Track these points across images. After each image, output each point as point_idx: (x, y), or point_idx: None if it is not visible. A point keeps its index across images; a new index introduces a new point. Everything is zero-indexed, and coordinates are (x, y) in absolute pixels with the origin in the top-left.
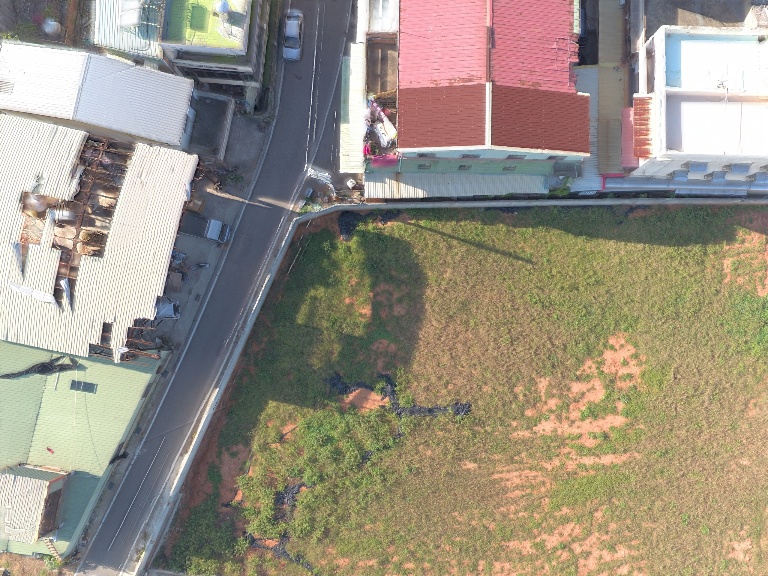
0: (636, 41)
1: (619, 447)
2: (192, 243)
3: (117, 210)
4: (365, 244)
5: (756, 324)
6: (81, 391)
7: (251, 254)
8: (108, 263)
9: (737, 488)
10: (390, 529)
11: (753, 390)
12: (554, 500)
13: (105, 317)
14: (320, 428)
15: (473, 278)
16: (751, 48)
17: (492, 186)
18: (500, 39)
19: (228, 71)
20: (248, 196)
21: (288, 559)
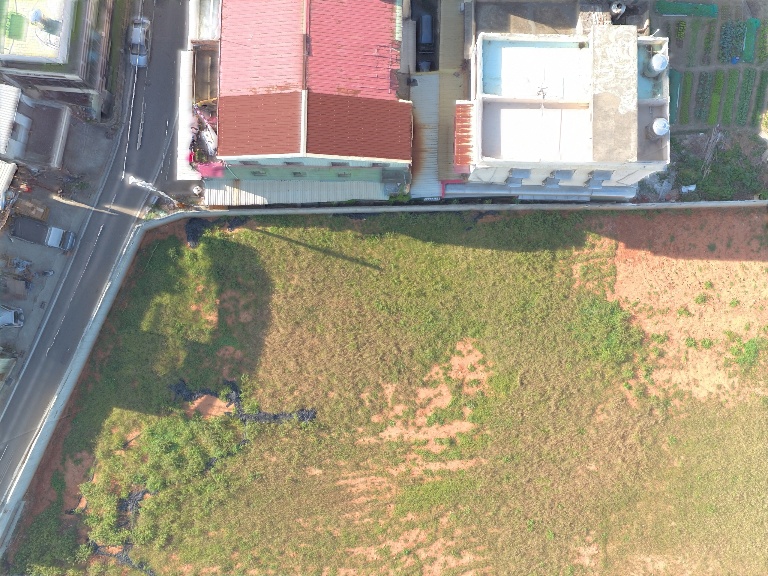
0: (469, 48)
1: (465, 453)
2: (37, 250)
3: None
4: (212, 251)
5: (603, 329)
6: None
7: (97, 261)
8: None
9: (583, 493)
10: (234, 536)
11: (600, 395)
12: (399, 506)
13: None
14: (164, 435)
15: (320, 284)
16: (572, 55)
17: (332, 193)
18: (317, 47)
19: (58, 79)
20: (95, 203)
21: (131, 566)
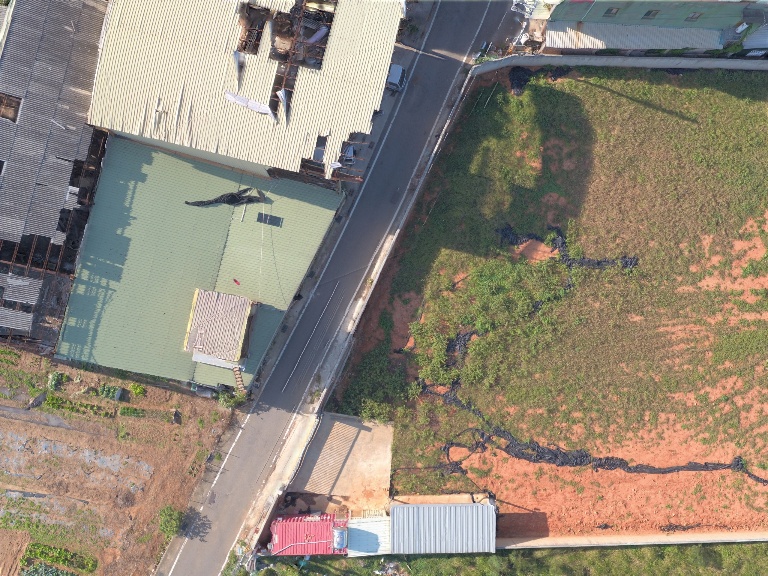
0: None
1: None
2: None
3: (334, 24)
4: (536, 98)
5: None
6: (267, 224)
7: (425, 104)
8: (325, 75)
9: None
10: (560, 378)
11: None
12: (718, 353)
13: (320, 130)
14: (492, 277)
15: (641, 135)
16: None
17: (669, 39)
18: None
19: None
20: (421, 47)
21: (460, 405)
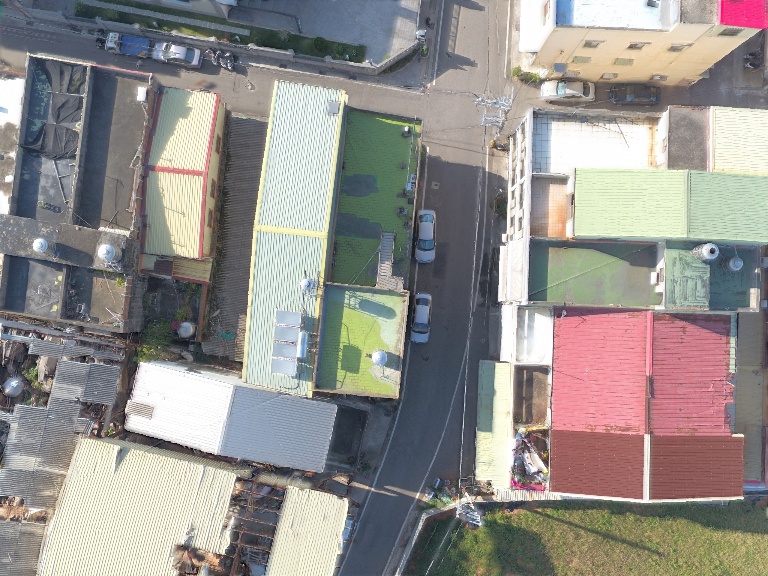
0: None
1: None
2: None
3: (269, 565)
4: (491, 534)
5: None
6: None
7: (376, 544)
8: None
9: None
10: None
11: None
12: None
13: None
14: None
15: (599, 569)
16: None
17: None
18: (659, 387)
19: None
20: (373, 483)
21: None
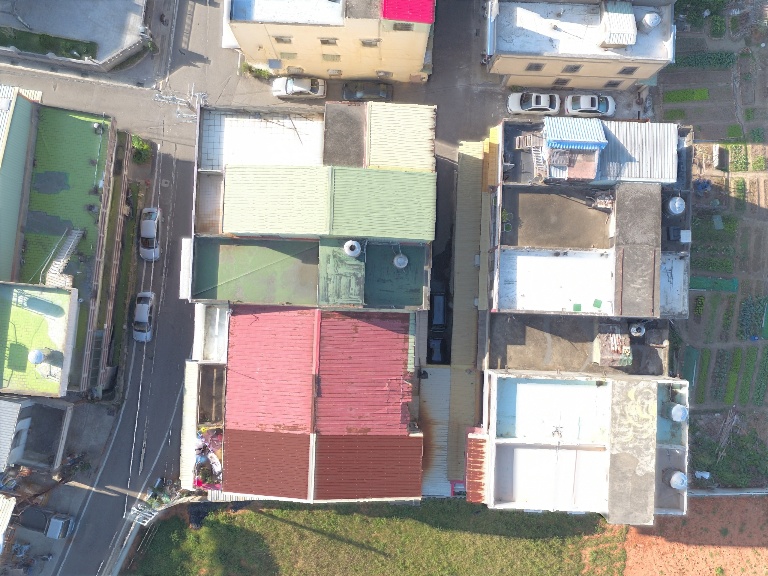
0: (482, 359)
1: None
2: (36, 533)
3: None
4: (214, 534)
5: None
6: None
7: (96, 544)
8: None
9: None
10: None
11: None
12: None
13: None
14: None
15: (324, 570)
16: (588, 393)
17: None
18: (327, 386)
19: None
20: (95, 483)
21: None
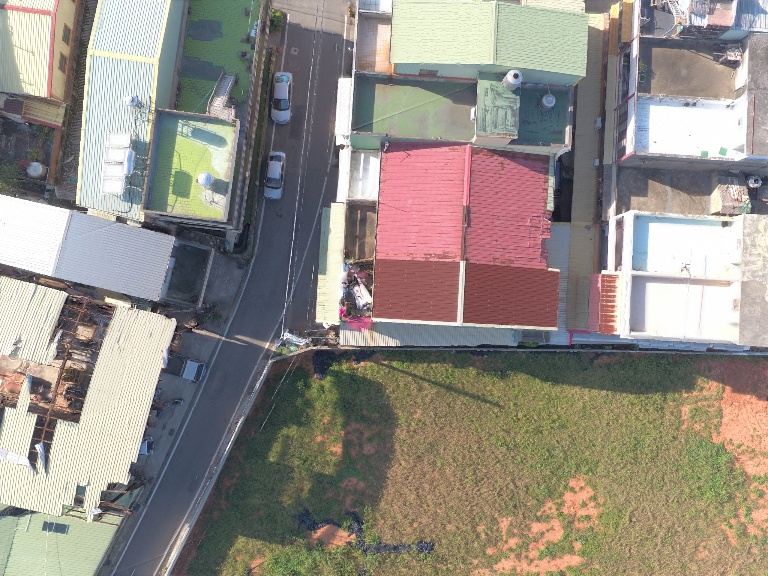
0: (607, 210)
1: None
2: (168, 378)
3: (94, 376)
4: (338, 384)
5: (709, 471)
6: (53, 532)
7: (226, 391)
8: (83, 428)
9: None
10: None
11: (703, 534)
12: None
13: (79, 480)
14: (288, 563)
15: (442, 420)
16: (715, 233)
17: (463, 338)
18: (476, 218)
19: (209, 225)
20: (225, 333)
21: None
